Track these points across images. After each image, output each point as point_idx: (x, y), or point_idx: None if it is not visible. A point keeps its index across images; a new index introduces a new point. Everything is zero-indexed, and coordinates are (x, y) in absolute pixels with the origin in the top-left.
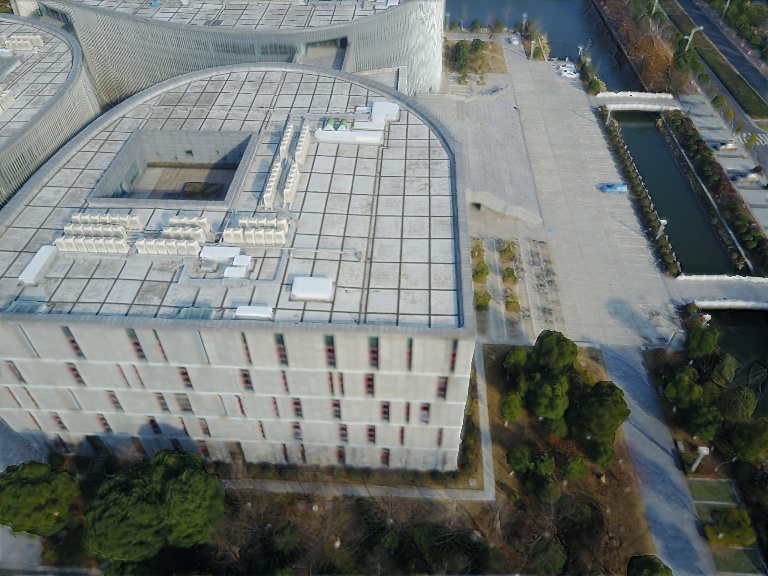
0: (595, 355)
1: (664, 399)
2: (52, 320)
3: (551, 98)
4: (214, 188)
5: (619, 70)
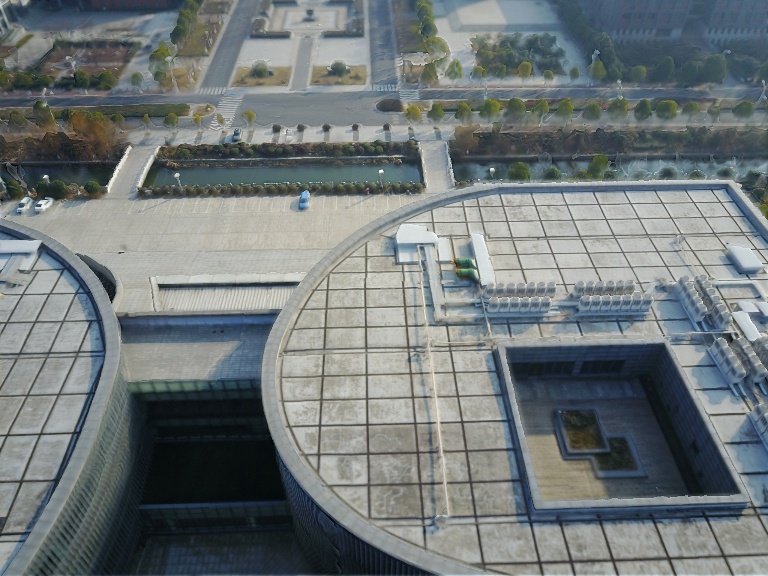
0: None
1: None
2: None
3: (100, 225)
4: (568, 416)
5: None
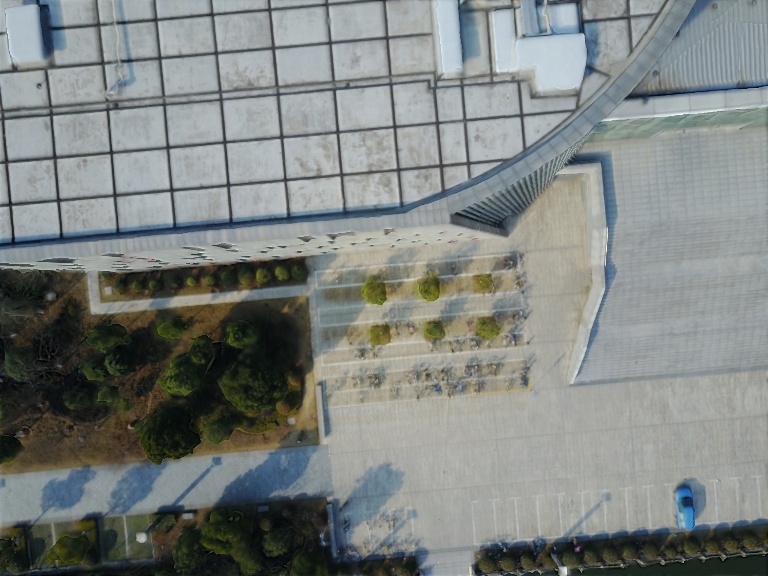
0: (308, 437)
1: (250, 510)
2: None
3: None
4: None
5: None
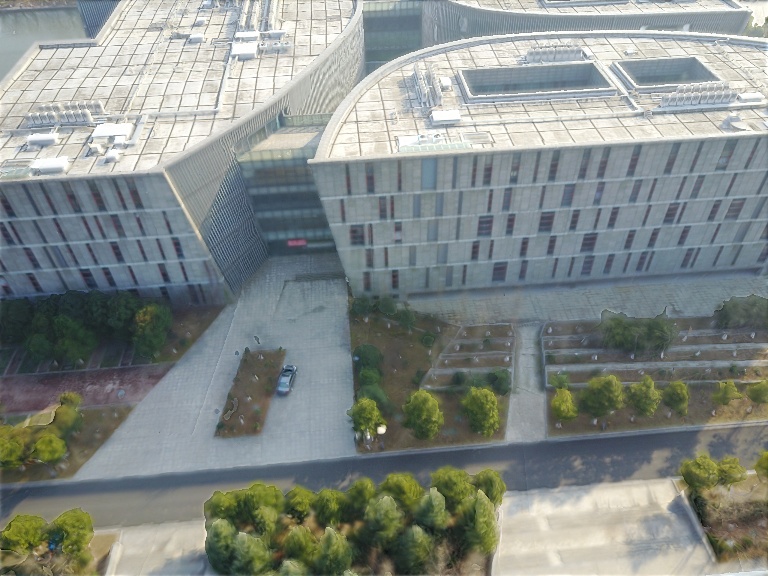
0: None
1: None
2: None
3: None
4: None
5: None
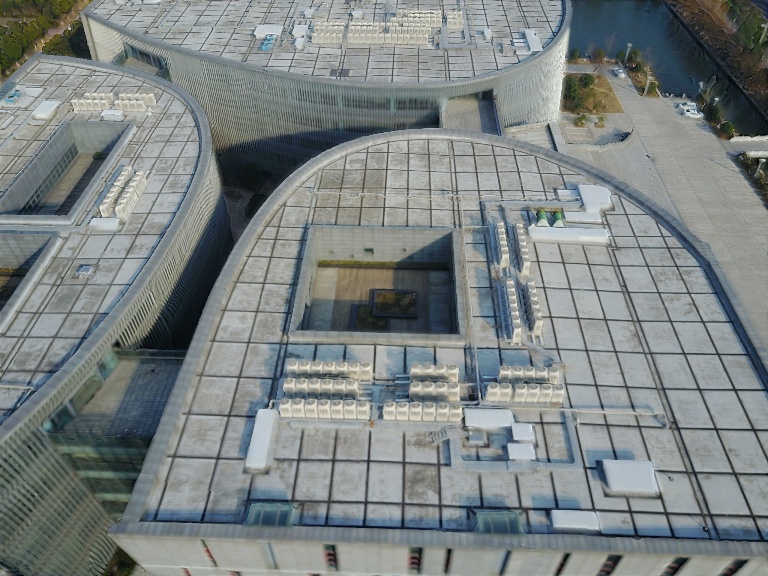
0: None
1: None
2: (315, 538)
3: (681, 143)
4: (409, 298)
5: (735, 106)
